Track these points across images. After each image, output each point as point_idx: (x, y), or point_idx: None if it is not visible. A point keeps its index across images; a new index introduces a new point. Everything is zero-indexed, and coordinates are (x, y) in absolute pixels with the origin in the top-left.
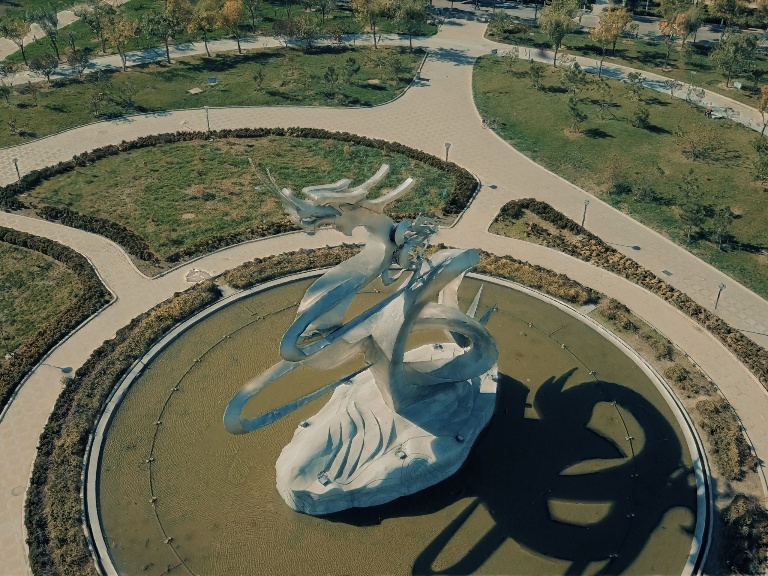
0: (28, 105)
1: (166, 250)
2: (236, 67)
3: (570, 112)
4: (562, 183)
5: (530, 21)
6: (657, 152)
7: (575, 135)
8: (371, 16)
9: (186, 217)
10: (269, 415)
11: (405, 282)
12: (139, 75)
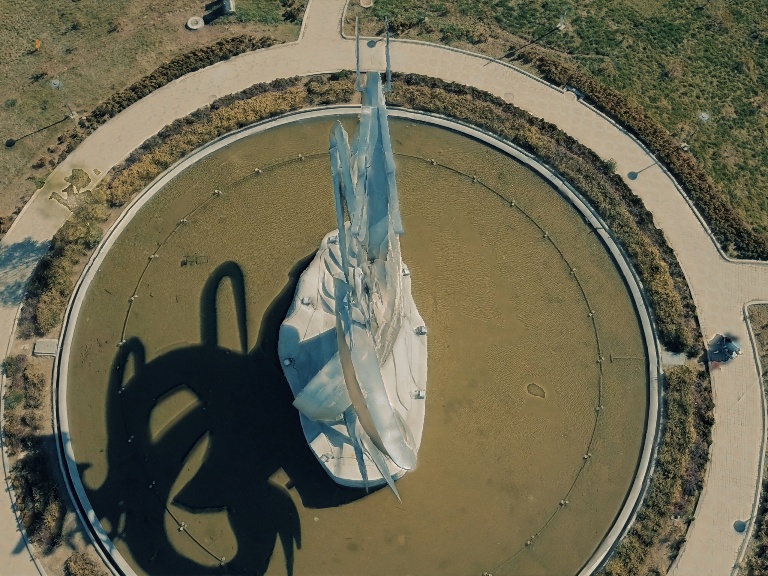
0: None
1: None
2: None
3: None
4: None
5: None
6: None
7: None
8: None
9: None
10: None
11: None
12: None
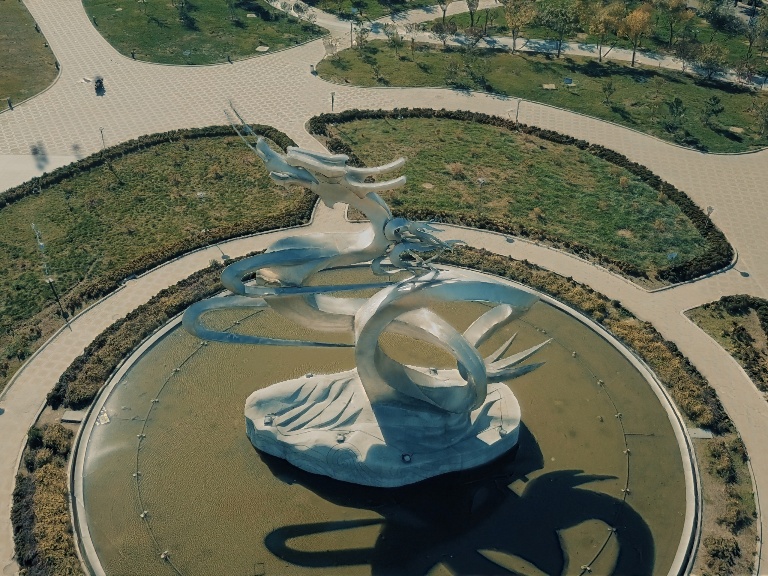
0: (407, 59)
1: None
2: (610, 76)
3: None
4: None
5: None
6: None
7: None
8: None
9: (425, 185)
10: (228, 335)
11: None
12: (518, 60)
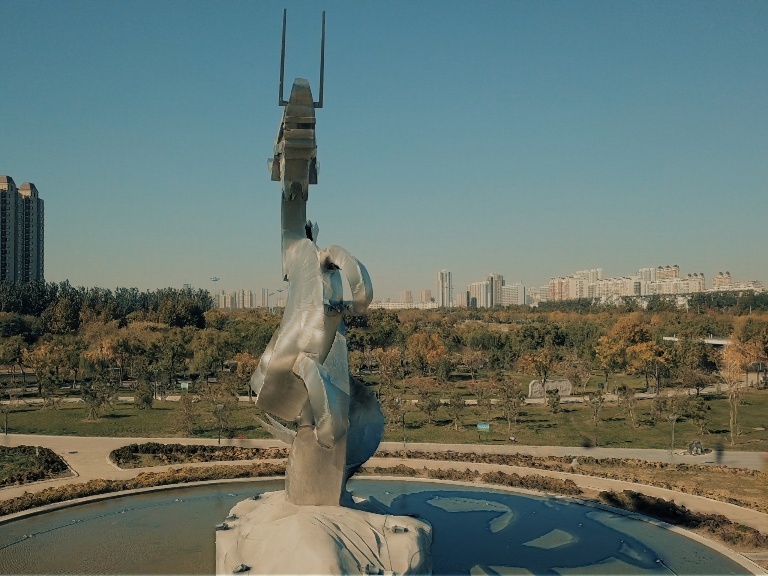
0: None
1: None
2: None
3: (84, 398)
4: (138, 439)
5: None
6: None
7: (97, 420)
8: None
9: None
10: None
11: None
12: None
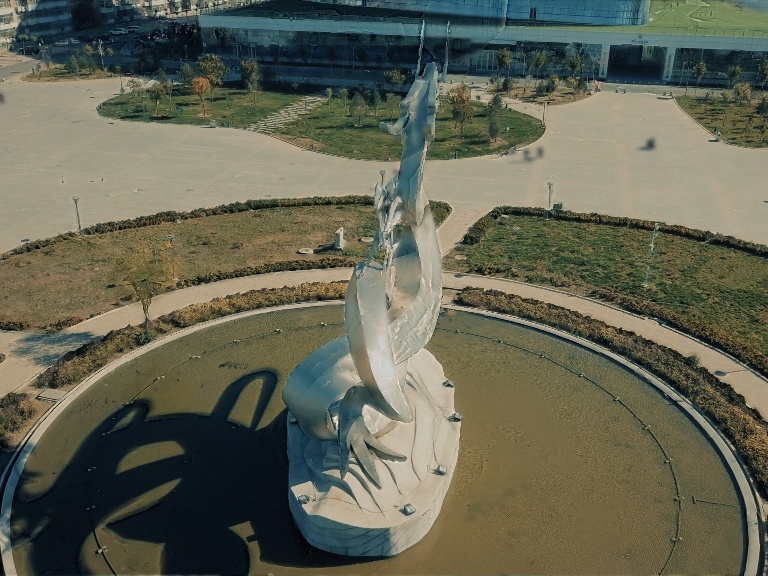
0: None
1: None
2: None
3: None
4: None
5: None
6: None
7: None
8: None
9: None
10: None
11: None
12: None
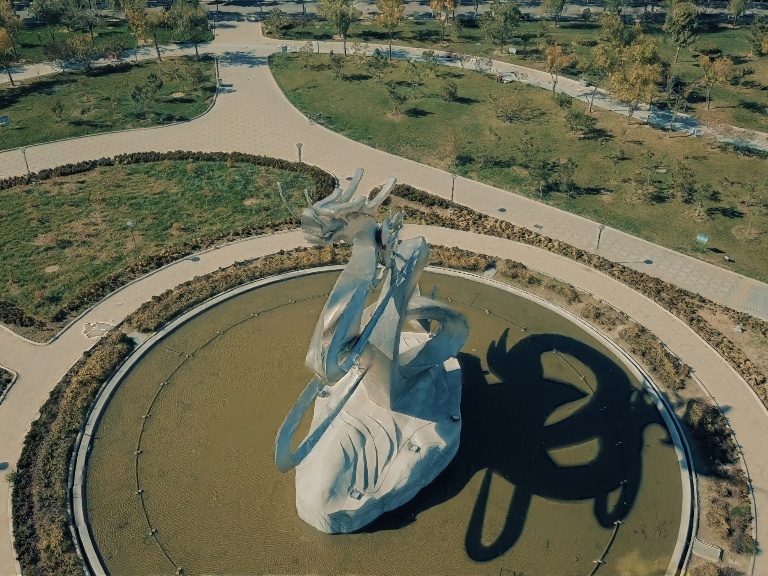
0: None
1: (46, 310)
2: (19, 101)
3: (390, 96)
4: (409, 164)
5: (298, 15)
6: (477, 121)
7: (399, 117)
8: (150, 28)
9: (50, 270)
10: (307, 444)
11: (387, 280)
12: None
